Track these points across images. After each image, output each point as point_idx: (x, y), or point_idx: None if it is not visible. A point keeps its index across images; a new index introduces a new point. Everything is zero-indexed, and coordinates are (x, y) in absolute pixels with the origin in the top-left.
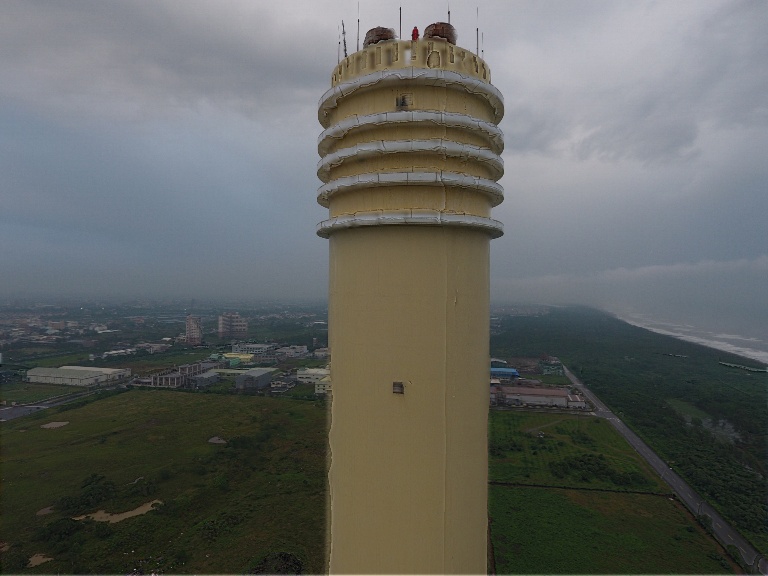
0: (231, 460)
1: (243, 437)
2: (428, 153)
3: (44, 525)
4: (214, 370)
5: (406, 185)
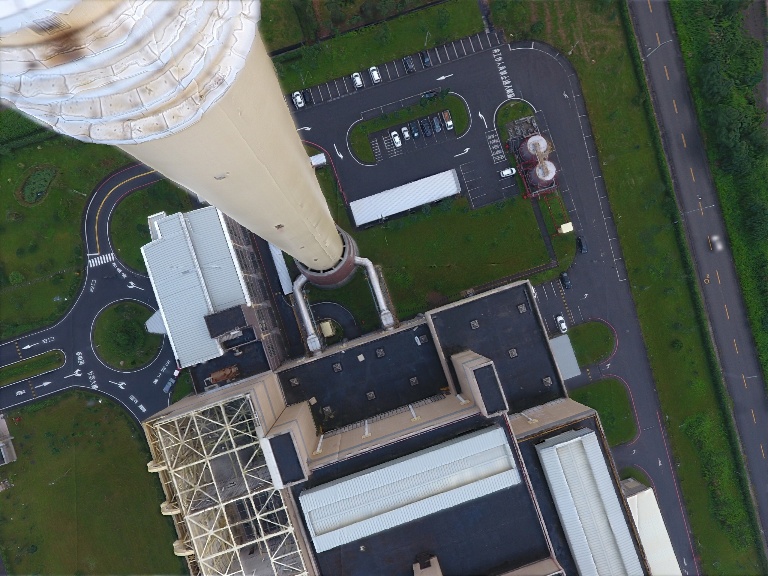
0: None
1: None
2: None
3: None
4: None
5: None
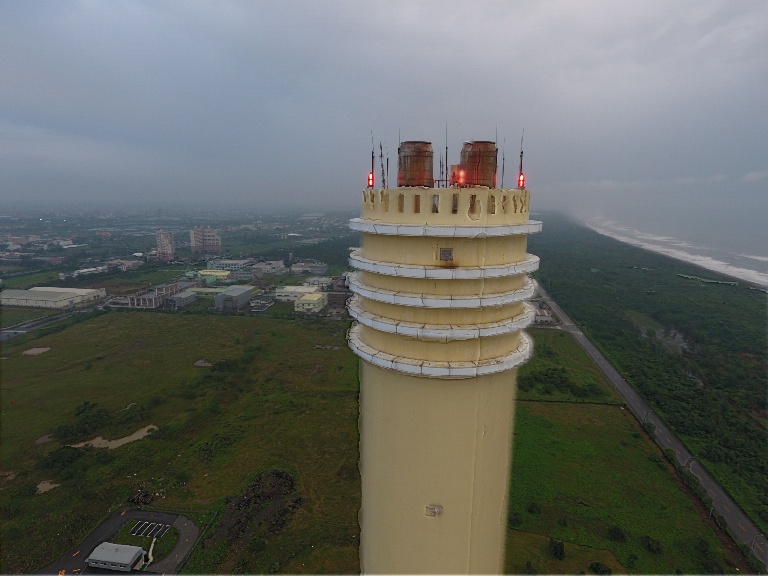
0: (219, 384)
1: (228, 360)
2: (466, 310)
3: (45, 453)
4: (191, 289)
5: (445, 343)
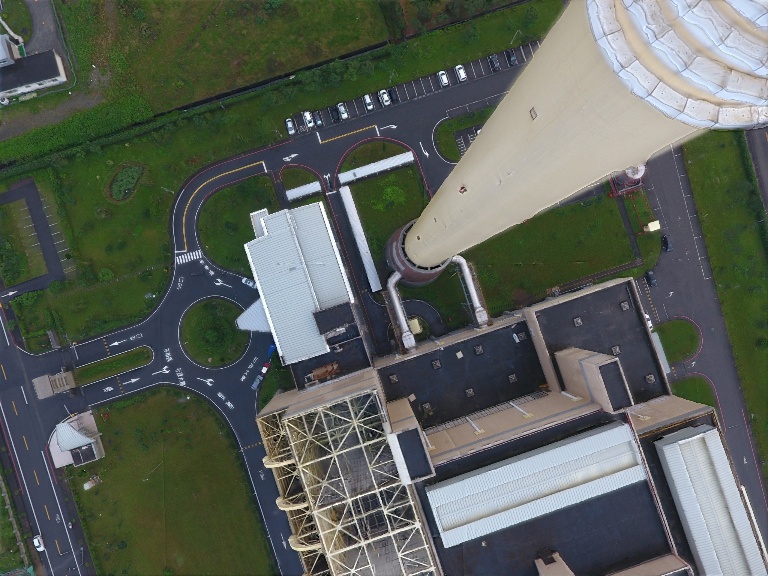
0: None
1: None
2: None
3: None
4: None
5: None
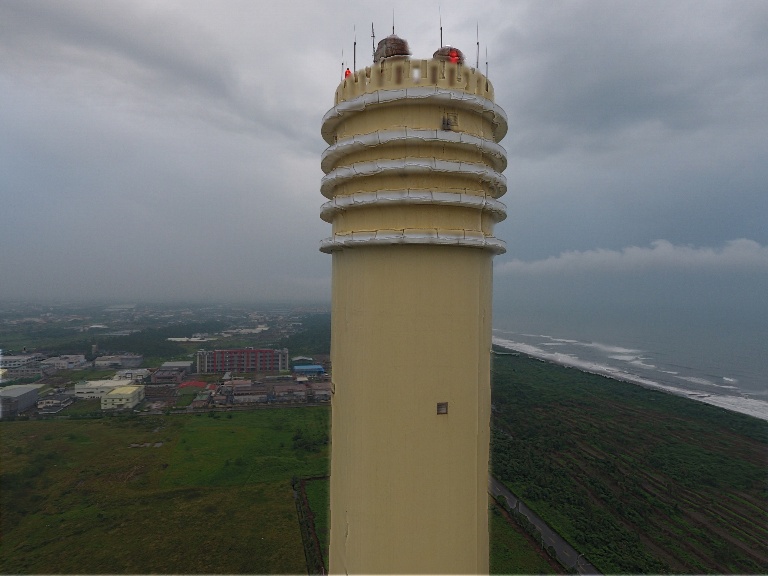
0: None
1: (4, 475)
2: (472, 176)
3: None
4: None
5: (457, 206)
